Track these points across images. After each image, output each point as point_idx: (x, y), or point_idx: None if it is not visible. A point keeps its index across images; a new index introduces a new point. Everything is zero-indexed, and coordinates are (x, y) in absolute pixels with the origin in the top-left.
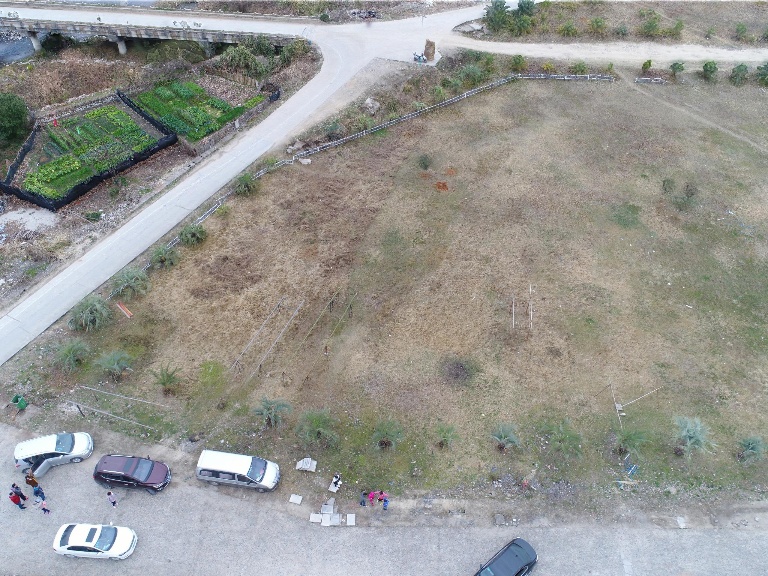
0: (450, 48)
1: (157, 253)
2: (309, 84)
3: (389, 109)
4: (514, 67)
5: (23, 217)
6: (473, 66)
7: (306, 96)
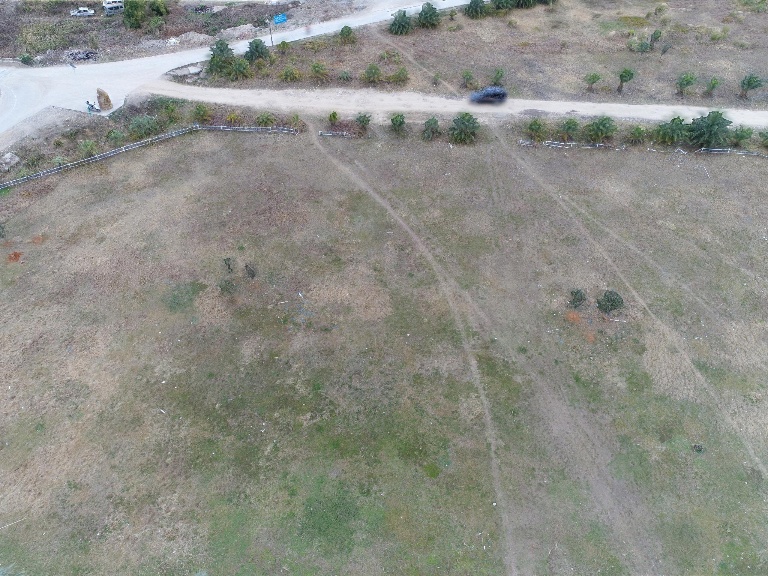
0: (141, 95)
1: None
2: None
3: (28, 165)
4: (196, 117)
5: None
6: (145, 117)
7: None
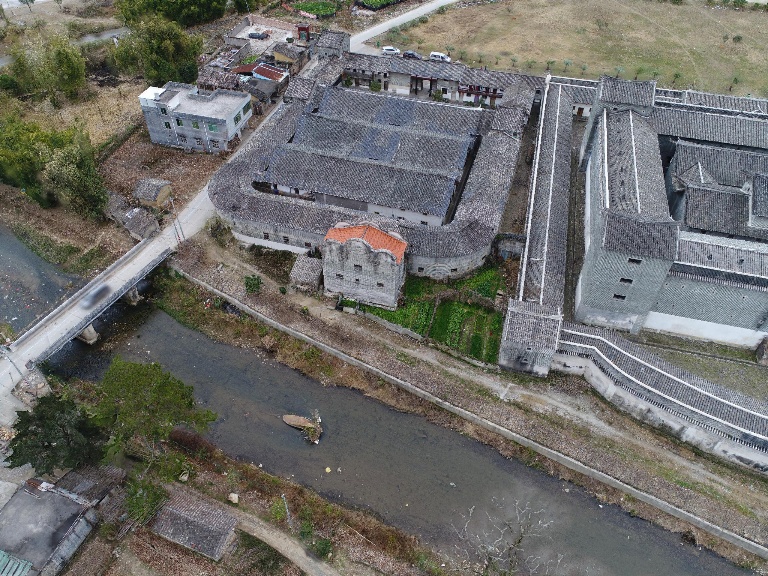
0: None
1: None
2: None
3: None
4: None
5: (364, 12)
6: None
7: None
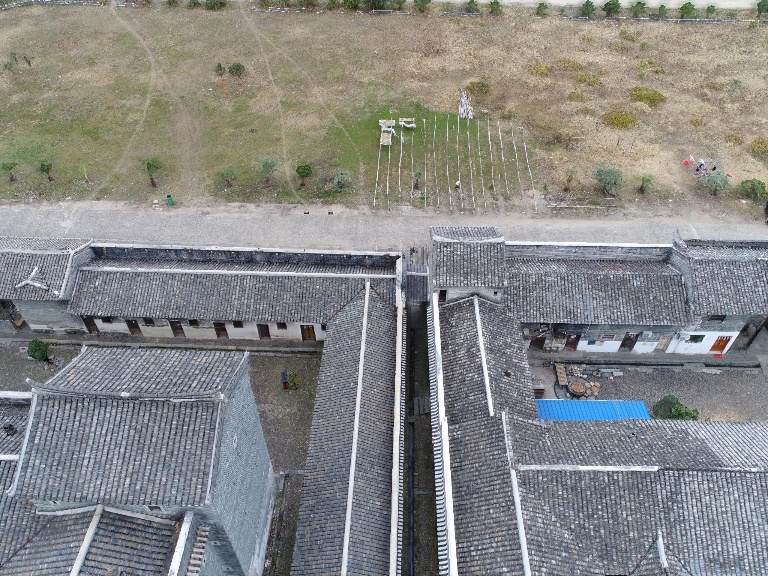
0: None
1: None
2: None
3: None
4: None
5: None
6: None
7: None
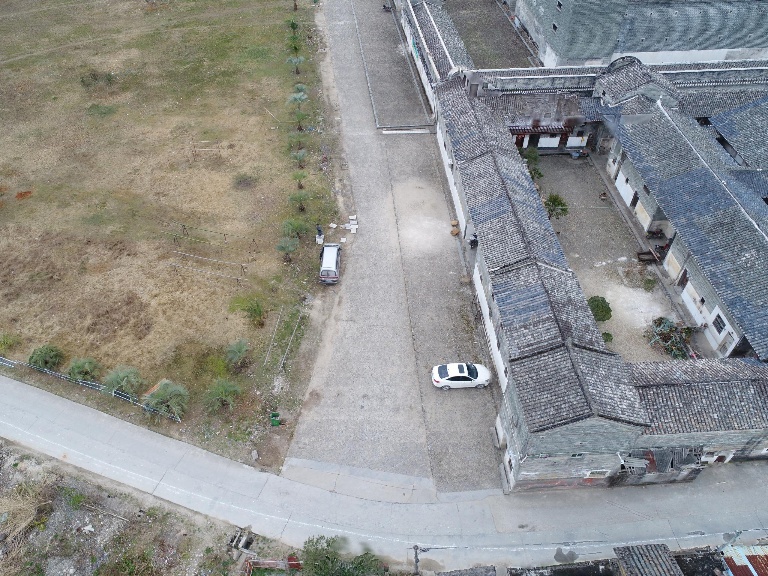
0: None
1: (81, 370)
2: None
3: None
4: None
5: None
6: None
7: None
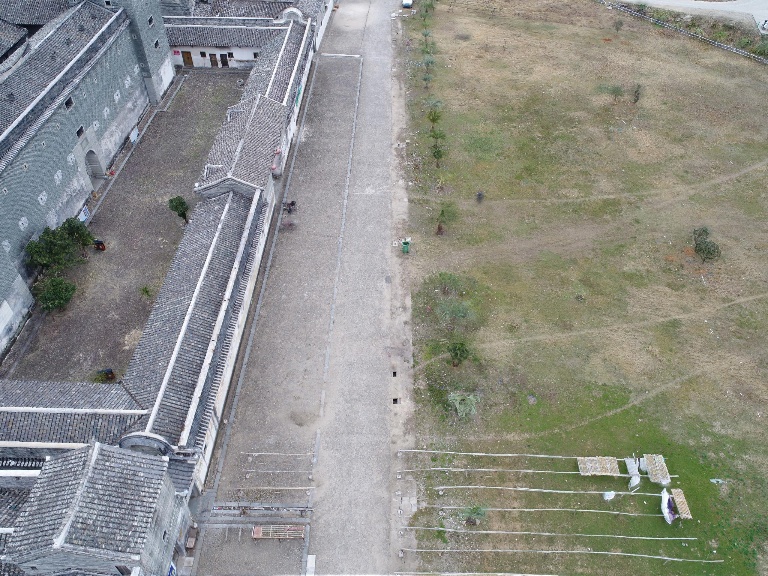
0: None
1: None
2: (696, 1)
3: None
4: None
5: None
6: None
7: (680, 2)
